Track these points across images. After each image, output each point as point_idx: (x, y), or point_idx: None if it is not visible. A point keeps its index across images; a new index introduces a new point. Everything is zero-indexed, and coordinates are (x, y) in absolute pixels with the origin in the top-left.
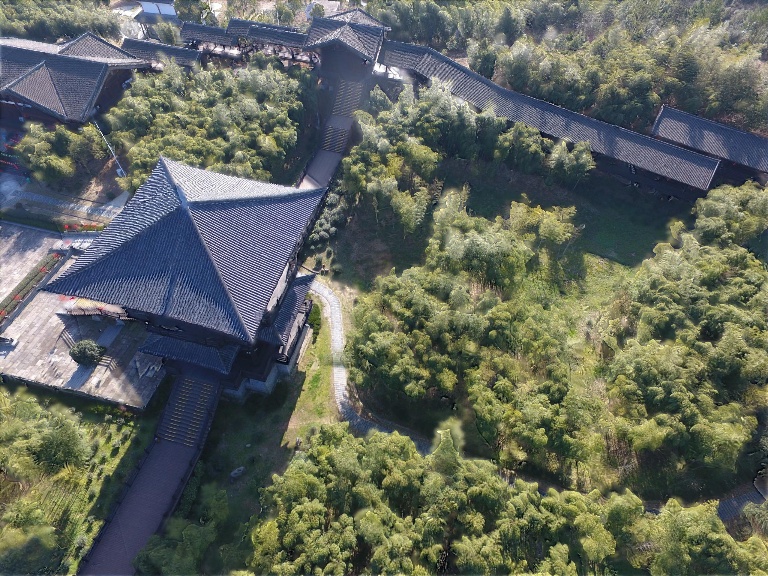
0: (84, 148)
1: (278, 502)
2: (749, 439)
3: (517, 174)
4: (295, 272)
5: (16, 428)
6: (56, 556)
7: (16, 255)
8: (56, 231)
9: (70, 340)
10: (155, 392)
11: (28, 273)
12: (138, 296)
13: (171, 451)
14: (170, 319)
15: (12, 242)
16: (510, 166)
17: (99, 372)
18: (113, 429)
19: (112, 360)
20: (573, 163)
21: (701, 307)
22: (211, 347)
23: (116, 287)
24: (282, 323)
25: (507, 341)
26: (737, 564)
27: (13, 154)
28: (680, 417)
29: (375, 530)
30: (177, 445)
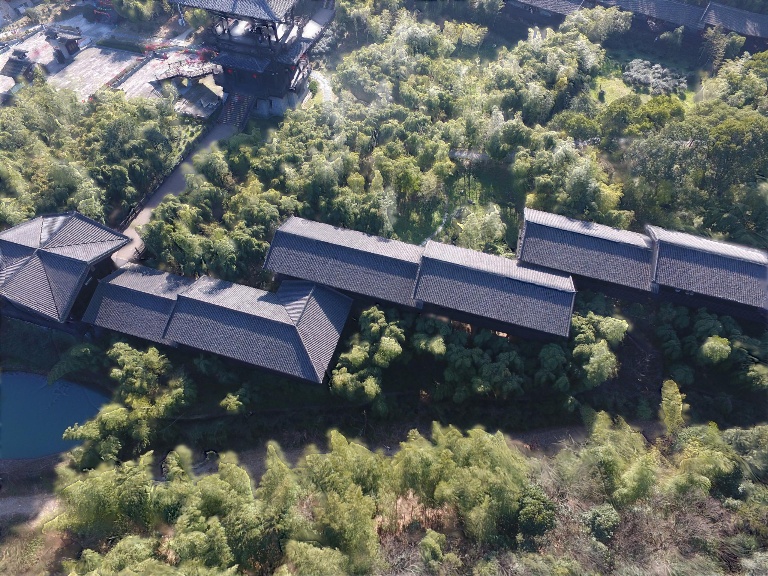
0: (157, 2)
1: (289, 118)
2: (555, 108)
3: (457, 22)
4: (302, 31)
5: (142, 98)
6: (169, 146)
7: (114, 63)
8: (139, 52)
9: (158, 93)
10: (214, 112)
11: (125, 68)
12: (218, 4)
13: (226, 127)
14: (229, 43)
15: (110, 57)
16: (452, 16)
17: (179, 104)
18: (190, 127)
19: (186, 100)
20: (488, 1)
21: (541, 51)
22: (252, 60)
23: (206, 0)
24: (293, 55)
25: (428, 75)
26: (525, 133)
27: (104, 11)
28: (513, 88)
29: (340, 122)
30: (230, 125)
